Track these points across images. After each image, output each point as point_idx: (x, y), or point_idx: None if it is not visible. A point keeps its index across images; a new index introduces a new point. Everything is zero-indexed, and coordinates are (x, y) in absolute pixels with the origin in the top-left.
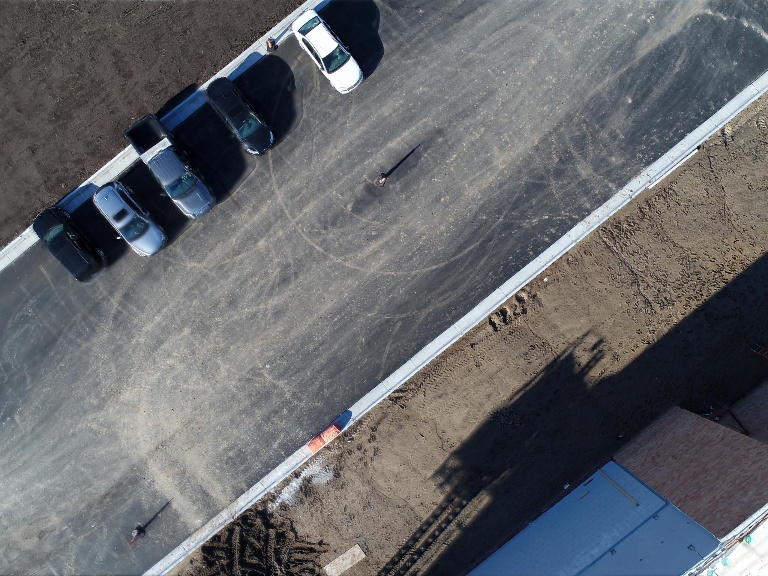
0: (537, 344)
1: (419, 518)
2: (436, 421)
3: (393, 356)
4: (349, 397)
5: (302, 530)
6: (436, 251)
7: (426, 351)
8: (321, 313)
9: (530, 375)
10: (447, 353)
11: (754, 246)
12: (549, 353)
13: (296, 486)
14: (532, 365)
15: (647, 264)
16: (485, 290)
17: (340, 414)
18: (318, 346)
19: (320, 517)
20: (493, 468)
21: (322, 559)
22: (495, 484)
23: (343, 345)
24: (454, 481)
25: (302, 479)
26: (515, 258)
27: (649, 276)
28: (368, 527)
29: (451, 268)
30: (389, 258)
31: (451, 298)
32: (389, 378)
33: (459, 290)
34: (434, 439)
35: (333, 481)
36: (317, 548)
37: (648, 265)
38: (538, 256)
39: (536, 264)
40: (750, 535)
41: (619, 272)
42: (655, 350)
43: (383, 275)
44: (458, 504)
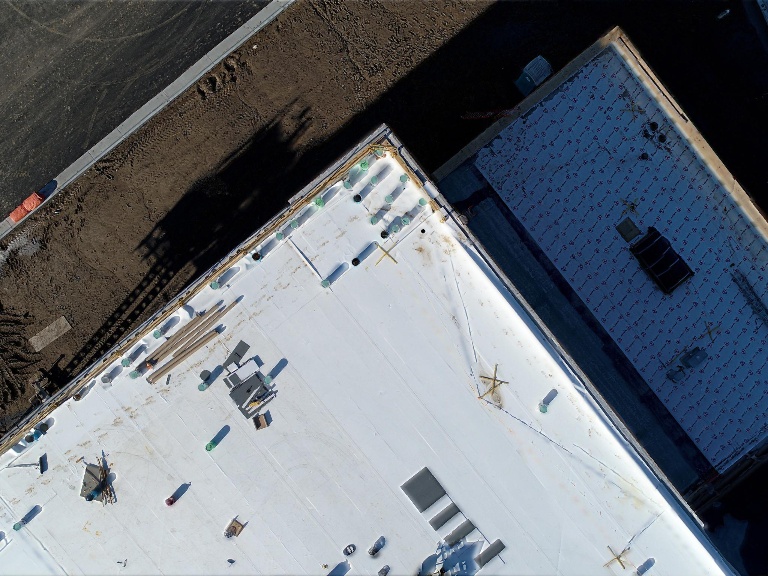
0: (246, 113)
1: (126, 289)
2: (143, 191)
3: (99, 125)
4: (55, 167)
5: (8, 302)
6: (143, 17)
7: (132, 119)
8: (26, 81)
9: (238, 143)
10: (155, 122)
11: (465, 12)
12: (258, 122)
13: (3, 259)
14: (240, 134)
15: (357, 30)
16: (193, 57)
17: (46, 184)
18: (23, 115)
19: (26, 289)
20: (201, 239)
21: (27, 331)
22: (203, 255)
23: (48, 113)
24: (161, 252)
25: (9, 252)
26: (223, 24)
27: (358, 42)
28: (74, 299)
29: (158, 35)
30: (95, 24)
31: (158, 65)
32: (95, 147)
33: (166, 57)
34: (141, 209)
35: (39, 253)
36: (23, 320)
37: (358, 31)
38: (246, 22)
39: (244, 30)
40: (327, 202)
41: (328, 39)
42: (364, 118)
43: (89, 42)
44: (165, 275)
